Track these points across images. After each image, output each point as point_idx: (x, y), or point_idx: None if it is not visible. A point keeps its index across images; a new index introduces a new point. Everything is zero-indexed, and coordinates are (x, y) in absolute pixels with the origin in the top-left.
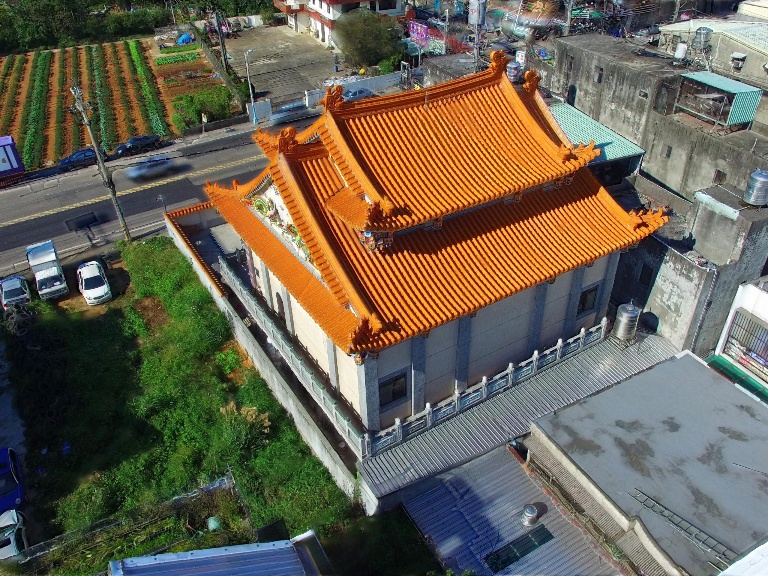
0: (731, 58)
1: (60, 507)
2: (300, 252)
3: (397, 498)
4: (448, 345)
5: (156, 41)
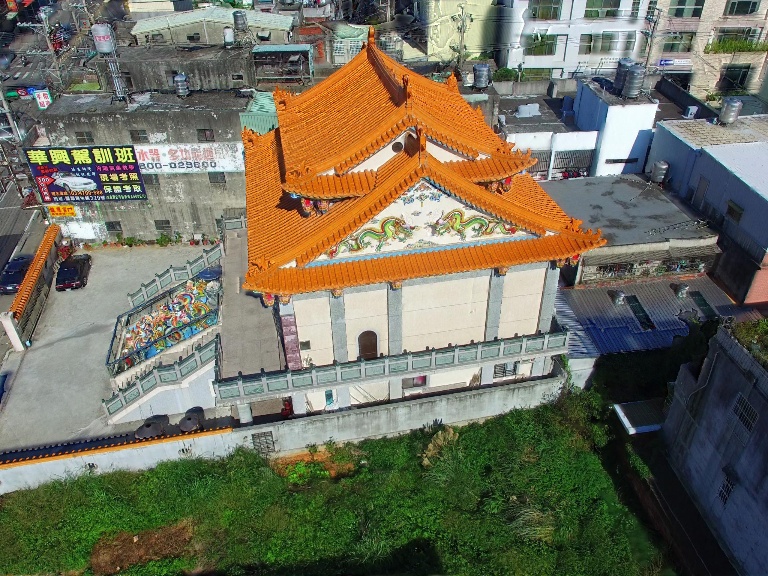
0: (223, 38)
1: None
2: (449, 240)
3: None
4: None
5: None
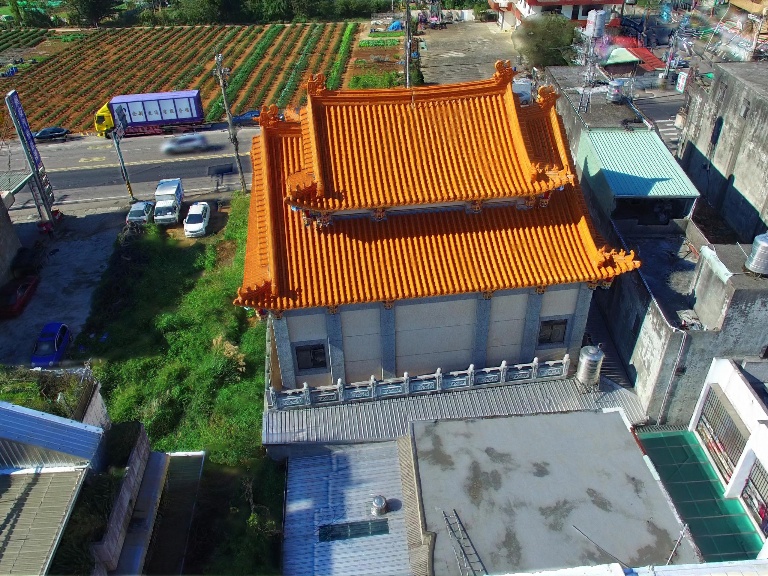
0: None
1: None
2: None
3: (284, 452)
4: (371, 331)
5: (371, 25)
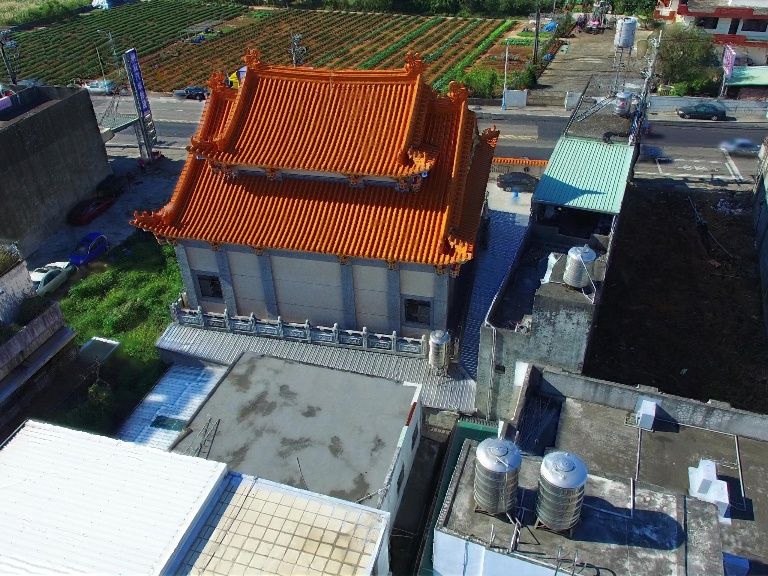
0: None
1: (90, 275)
2: None
3: (171, 357)
4: (255, 274)
5: (528, 24)
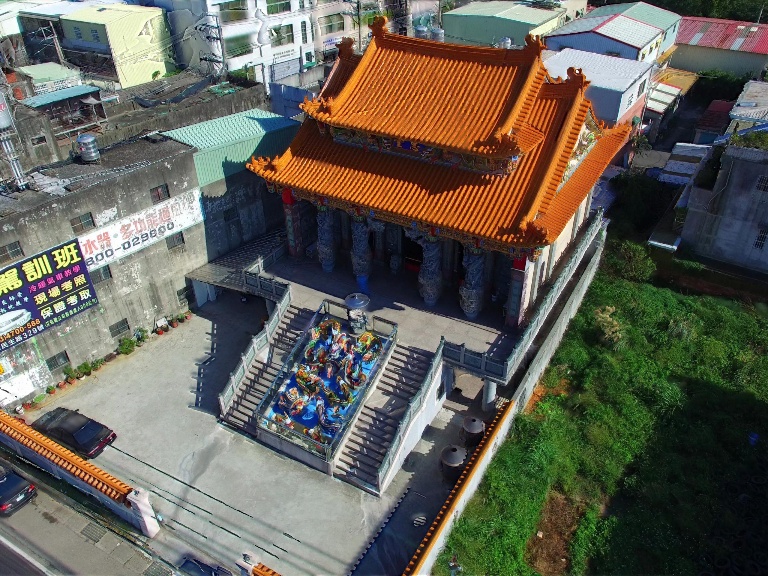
0: None
1: None
2: None
3: None
4: None
5: None
